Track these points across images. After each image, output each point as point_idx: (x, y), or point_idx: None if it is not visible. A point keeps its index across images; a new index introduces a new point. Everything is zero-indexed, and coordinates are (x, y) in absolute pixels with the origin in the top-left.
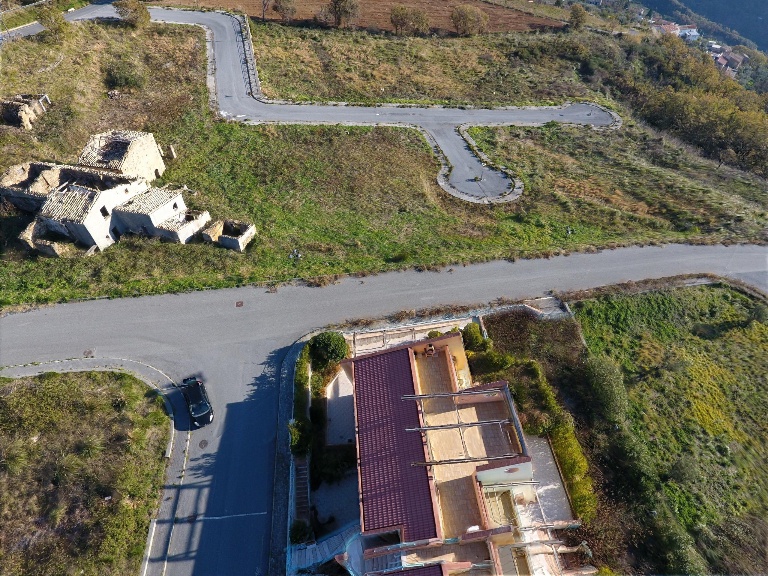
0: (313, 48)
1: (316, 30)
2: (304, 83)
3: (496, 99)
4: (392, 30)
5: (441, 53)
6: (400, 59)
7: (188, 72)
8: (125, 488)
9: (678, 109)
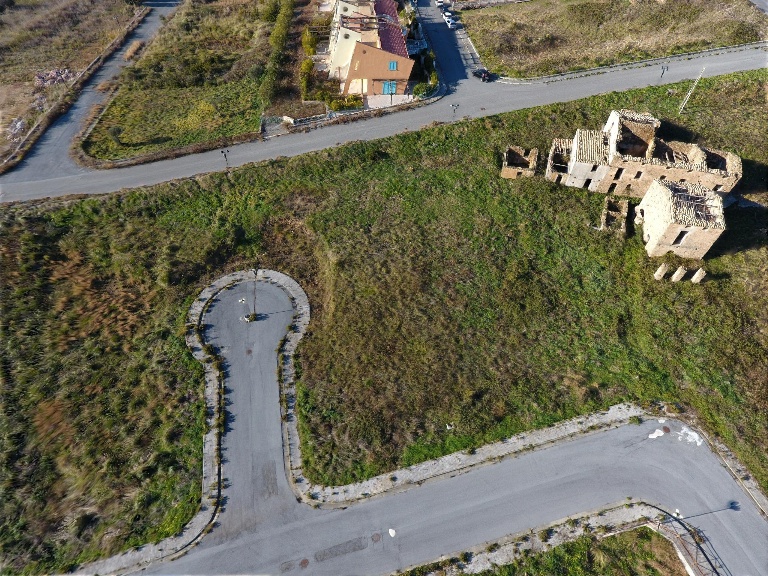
0: None
1: None
2: None
3: None
4: None
5: None
6: None
7: None
8: None
9: None
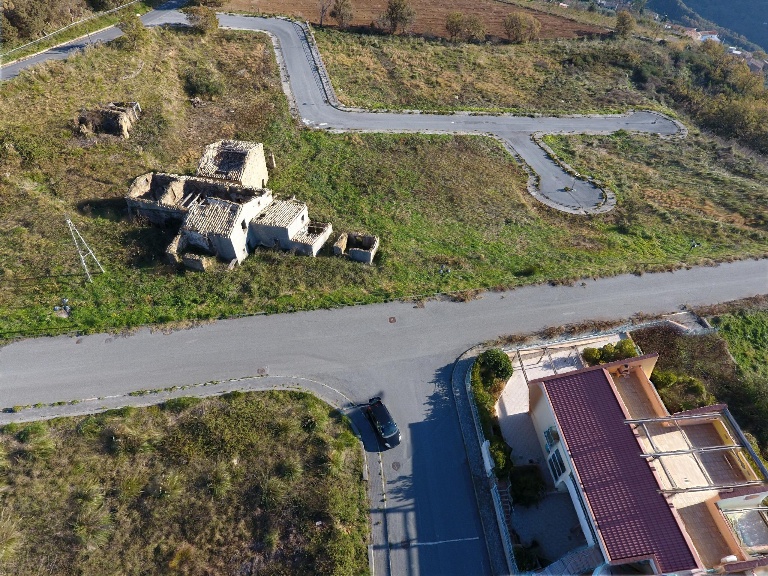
0: (374, 55)
1: (374, 36)
2: (374, 90)
3: (560, 107)
4: (445, 37)
5: (497, 60)
6: (460, 66)
7: (264, 79)
8: (337, 513)
9: (737, 117)
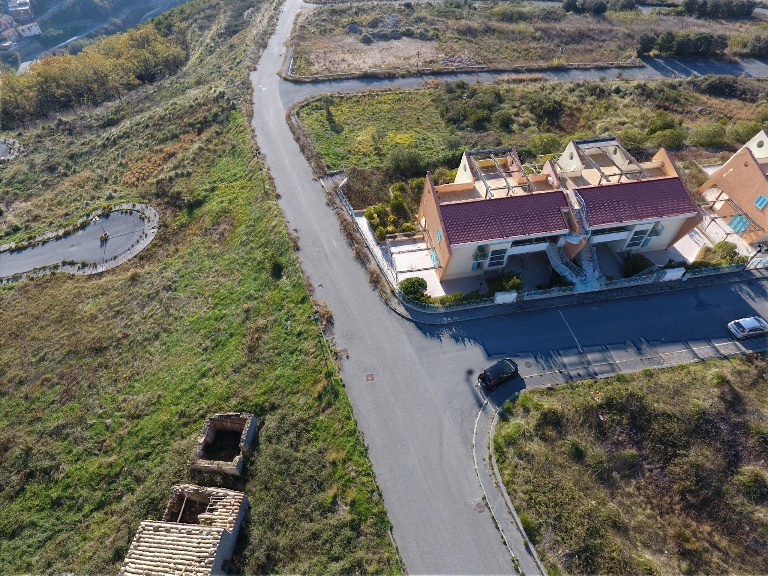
0: None
1: None
2: None
3: None
4: None
5: None
6: None
7: None
8: None
9: None
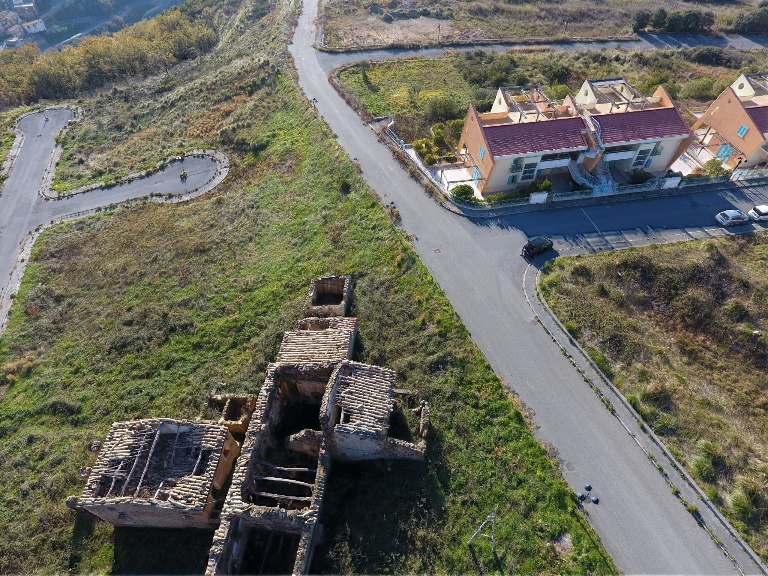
0: None
1: None
2: None
3: None
4: None
5: None
6: None
7: None
8: None
9: (52, 78)
